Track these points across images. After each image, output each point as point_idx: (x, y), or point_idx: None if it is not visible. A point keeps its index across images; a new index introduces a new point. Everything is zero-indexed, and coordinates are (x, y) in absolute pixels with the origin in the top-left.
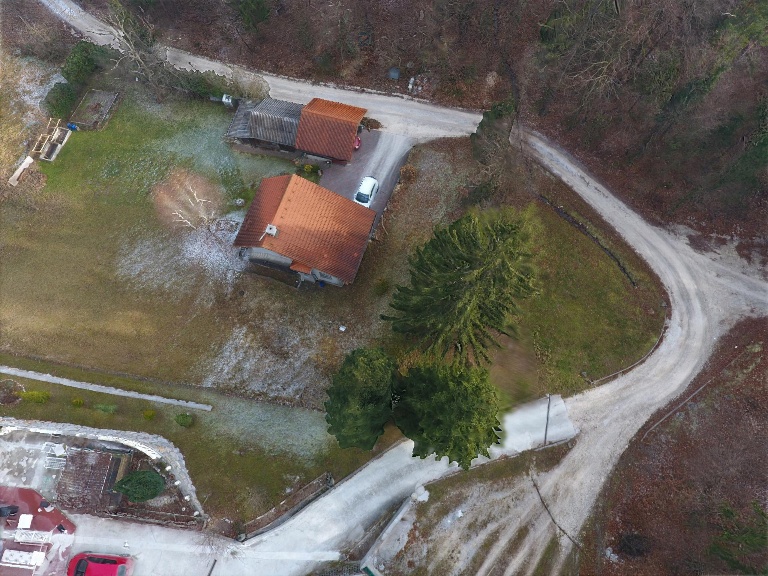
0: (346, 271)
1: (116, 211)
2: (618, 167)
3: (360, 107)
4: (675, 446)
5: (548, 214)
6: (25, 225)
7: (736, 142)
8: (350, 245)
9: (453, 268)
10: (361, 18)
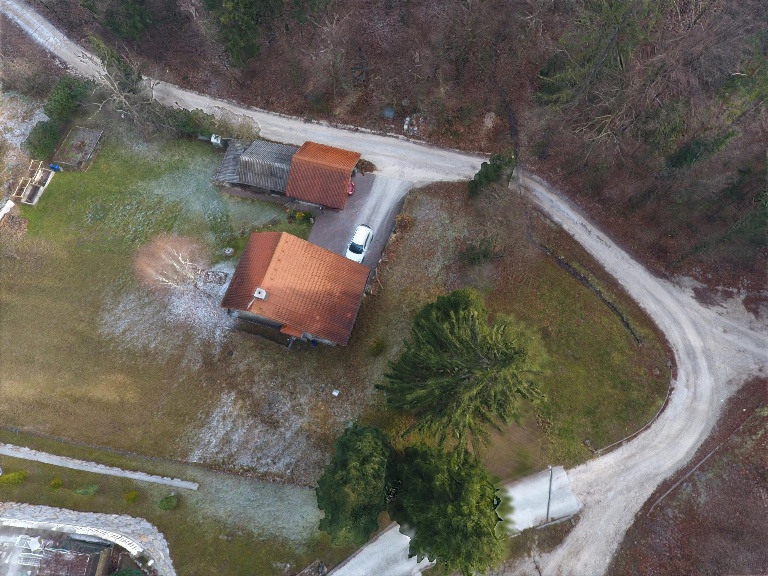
0: (339, 333)
1: (100, 260)
2: (621, 215)
3: (354, 148)
4: (683, 522)
5: (549, 266)
6: (5, 276)
7: (745, 199)
8: (343, 305)
9: (451, 370)
10: (355, 52)
